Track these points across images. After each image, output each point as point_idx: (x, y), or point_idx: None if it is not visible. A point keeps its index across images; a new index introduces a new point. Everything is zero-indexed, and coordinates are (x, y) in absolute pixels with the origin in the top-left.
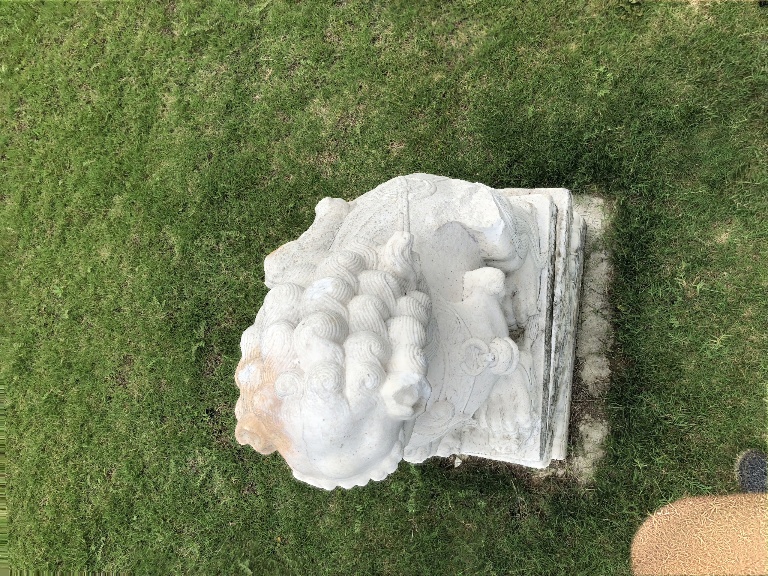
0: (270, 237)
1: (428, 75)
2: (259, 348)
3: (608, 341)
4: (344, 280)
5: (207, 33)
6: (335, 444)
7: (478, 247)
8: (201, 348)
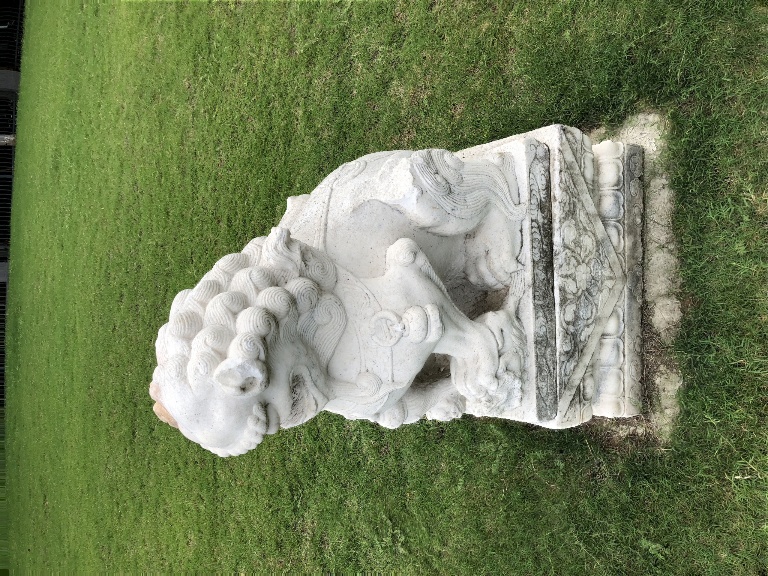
0: None
1: (477, 27)
2: None
3: (677, 279)
4: (212, 282)
5: (314, 45)
6: (192, 420)
7: (407, 218)
8: None
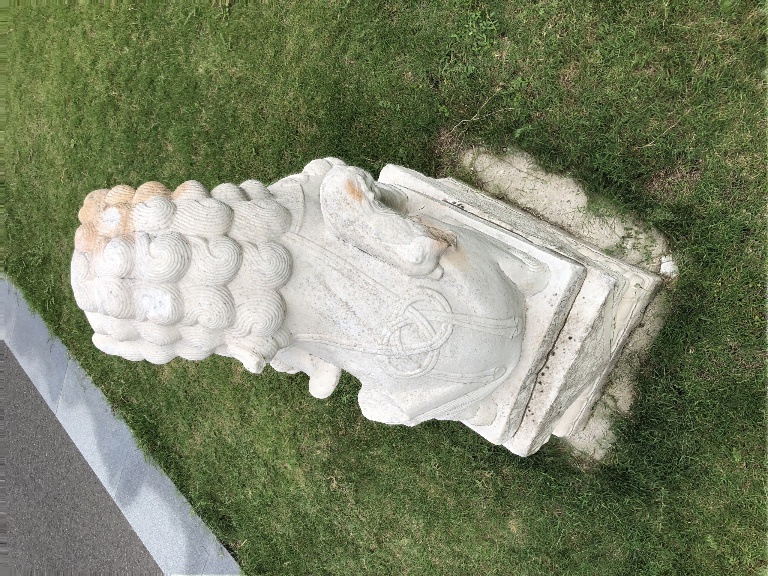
0: (749, 7)
1: None
2: (133, 229)
3: None
4: (174, 321)
5: None
6: None
7: None
8: None
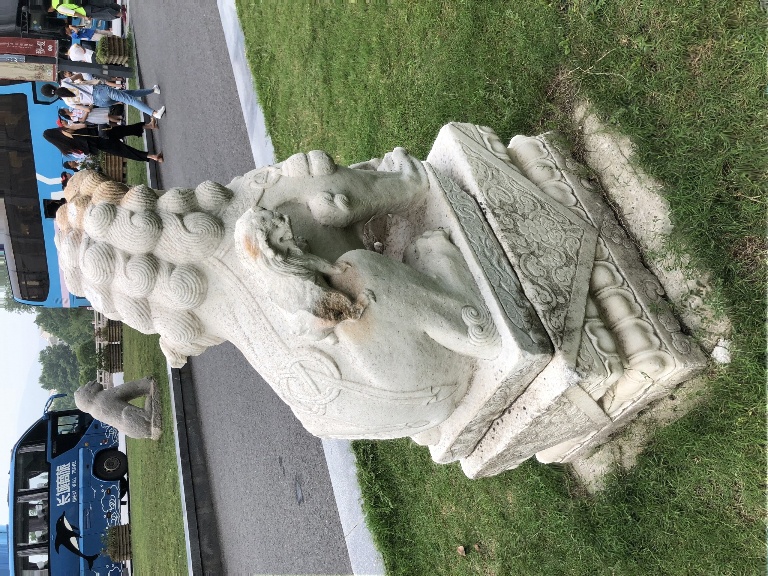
0: None
1: None
2: None
3: None
4: None
5: None
6: None
7: None
8: None
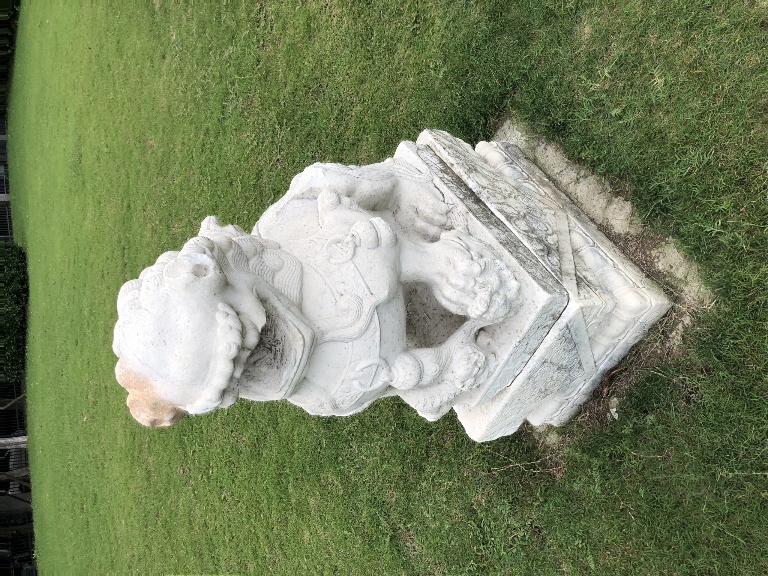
0: None
1: None
2: None
3: (605, 186)
4: None
5: None
6: (158, 345)
7: None
8: (393, 537)
